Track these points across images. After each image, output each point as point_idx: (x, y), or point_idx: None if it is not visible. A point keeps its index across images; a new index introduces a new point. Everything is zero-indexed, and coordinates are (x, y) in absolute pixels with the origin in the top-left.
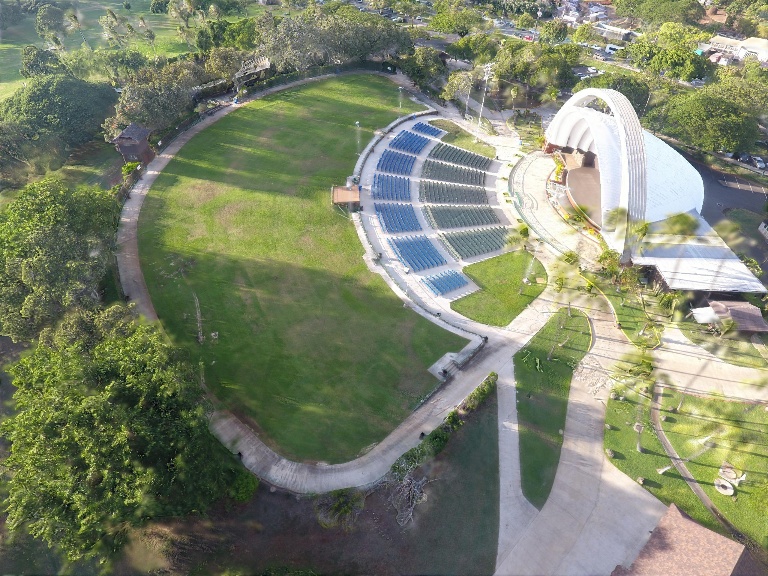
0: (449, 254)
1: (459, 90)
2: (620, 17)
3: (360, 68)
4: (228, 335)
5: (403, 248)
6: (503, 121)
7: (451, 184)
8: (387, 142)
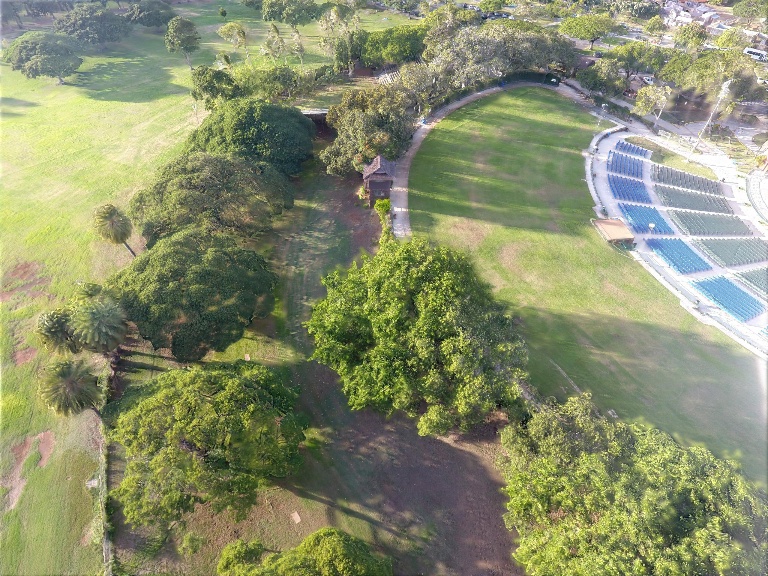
0: (761, 298)
1: (659, 105)
2: (735, 17)
3: (521, 80)
4: (627, 413)
5: (715, 293)
6: (695, 136)
7: (699, 212)
8: (601, 165)
